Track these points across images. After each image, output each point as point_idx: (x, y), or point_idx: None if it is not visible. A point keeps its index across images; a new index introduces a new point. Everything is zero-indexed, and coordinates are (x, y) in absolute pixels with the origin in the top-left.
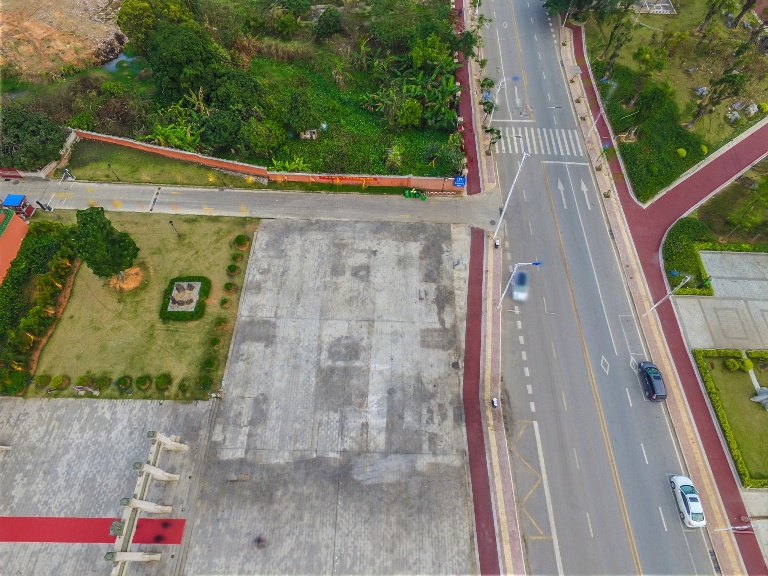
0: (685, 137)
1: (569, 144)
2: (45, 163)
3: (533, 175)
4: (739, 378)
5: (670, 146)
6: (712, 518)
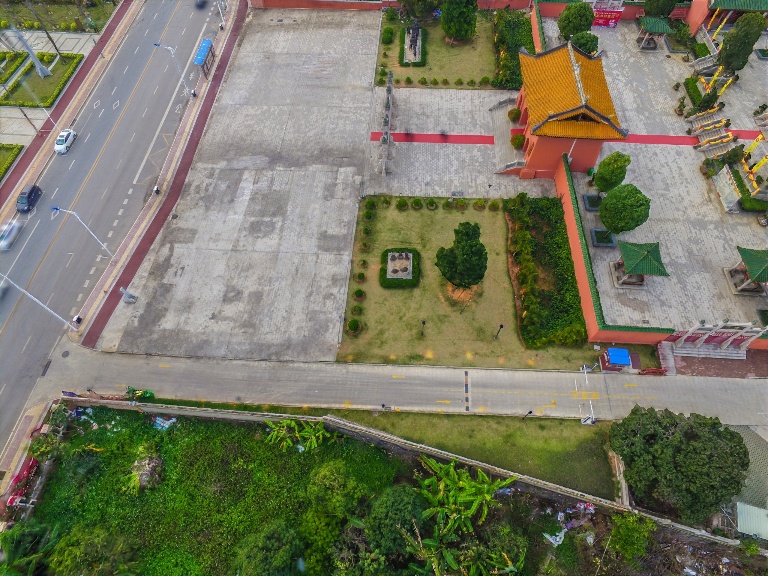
0: None
1: None
2: None
3: None
4: None
5: None
6: None
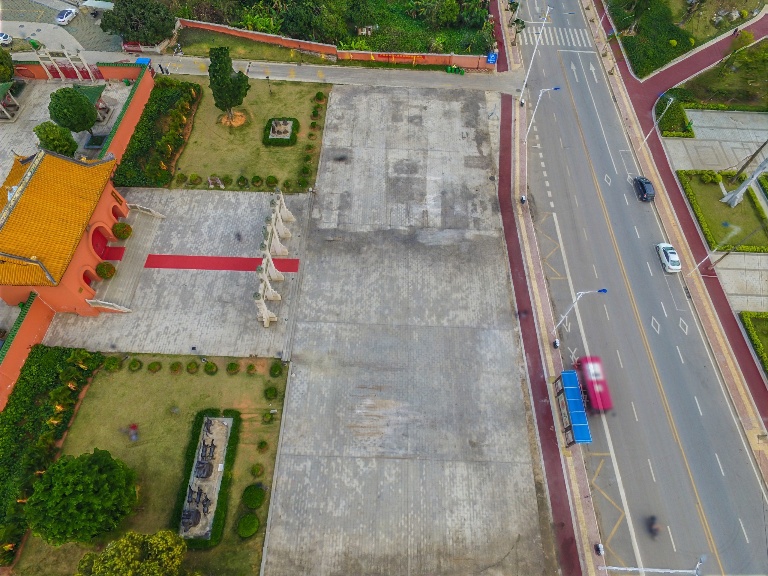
0: (676, 31)
1: (580, 39)
2: (162, 39)
3: (551, 59)
4: (711, 188)
5: (663, 38)
6: (686, 268)
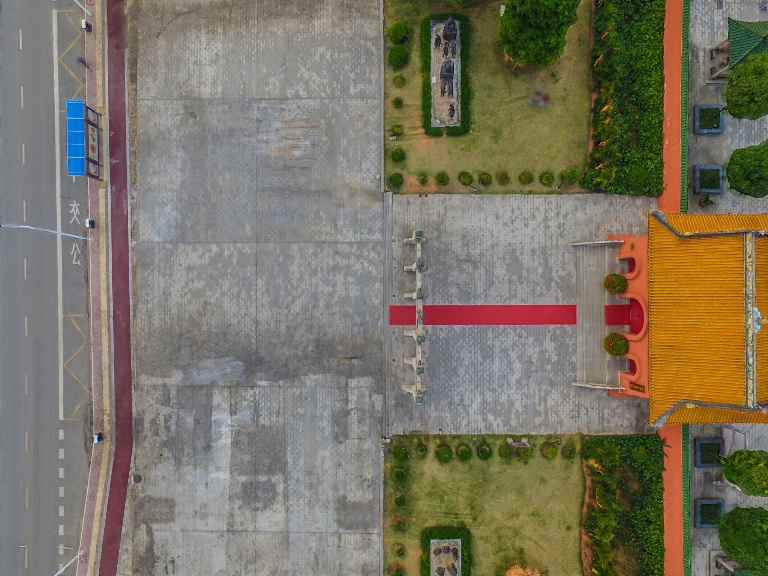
0: None
1: None
2: None
3: None
4: None
5: None
6: None
